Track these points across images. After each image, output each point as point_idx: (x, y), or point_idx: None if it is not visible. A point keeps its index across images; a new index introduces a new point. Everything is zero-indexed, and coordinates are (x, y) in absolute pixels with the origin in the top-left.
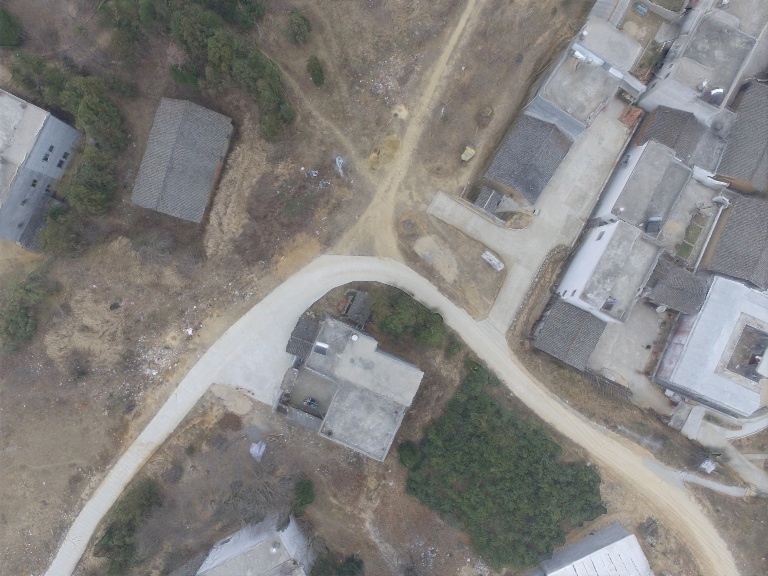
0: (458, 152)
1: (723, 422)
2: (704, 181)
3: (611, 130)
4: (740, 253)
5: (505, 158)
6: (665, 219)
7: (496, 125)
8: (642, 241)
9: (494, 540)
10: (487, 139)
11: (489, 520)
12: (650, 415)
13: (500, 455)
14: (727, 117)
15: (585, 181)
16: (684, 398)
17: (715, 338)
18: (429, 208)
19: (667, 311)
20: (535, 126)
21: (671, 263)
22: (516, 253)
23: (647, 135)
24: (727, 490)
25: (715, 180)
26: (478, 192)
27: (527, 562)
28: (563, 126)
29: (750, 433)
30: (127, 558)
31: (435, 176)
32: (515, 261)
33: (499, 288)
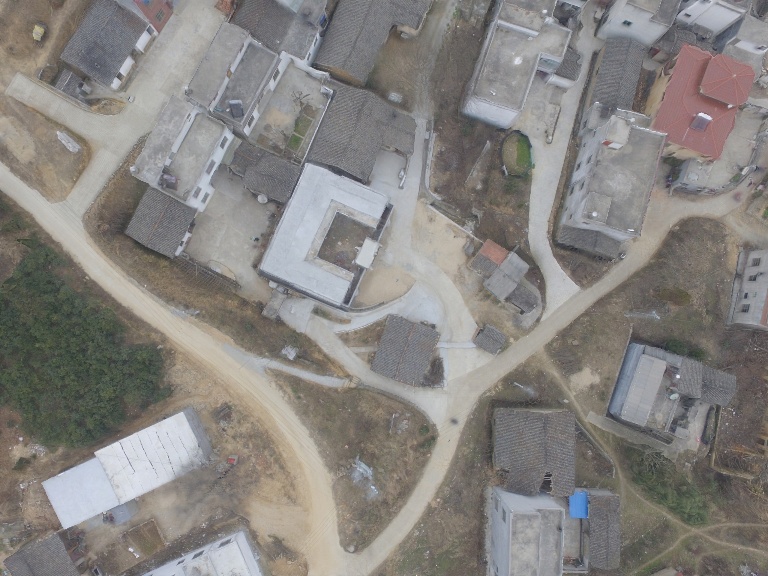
0: (27, 31)
1: (331, 315)
2: (310, 72)
3: (208, 17)
4: (334, 141)
5: (78, 38)
6: (249, 104)
7: (71, 6)
8: (210, 121)
9: (37, 416)
10: (64, 20)
11: (32, 396)
12: (255, 307)
13: (48, 331)
14: (318, 3)
15: (181, 68)
16: (288, 290)
17: (298, 223)
18: (7, 90)
19: (276, 203)
20: (106, 5)
21: (280, 155)
22: (104, 138)
23: (238, 21)
24: (319, 379)
25: (316, 70)
26: (59, 75)
27: (73, 439)
28: (123, 2)
29: (359, 327)
30: None
31: (14, 58)
32: (102, 146)
33: (79, 171)
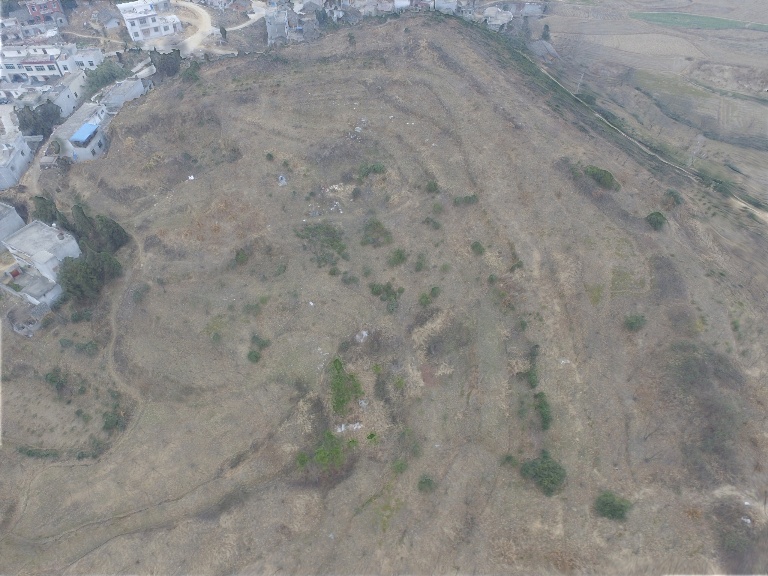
0: None
1: None
2: None
3: None
4: None
5: None
6: None
7: None
8: None
9: None
10: None
11: None
12: None
13: None
14: None
15: None
16: None
17: None
18: None
19: None
20: None
21: None
22: None
23: None
24: None
25: None
26: None
27: (130, 0)
28: None
29: None
30: (2, 3)
31: None
32: None
33: None
